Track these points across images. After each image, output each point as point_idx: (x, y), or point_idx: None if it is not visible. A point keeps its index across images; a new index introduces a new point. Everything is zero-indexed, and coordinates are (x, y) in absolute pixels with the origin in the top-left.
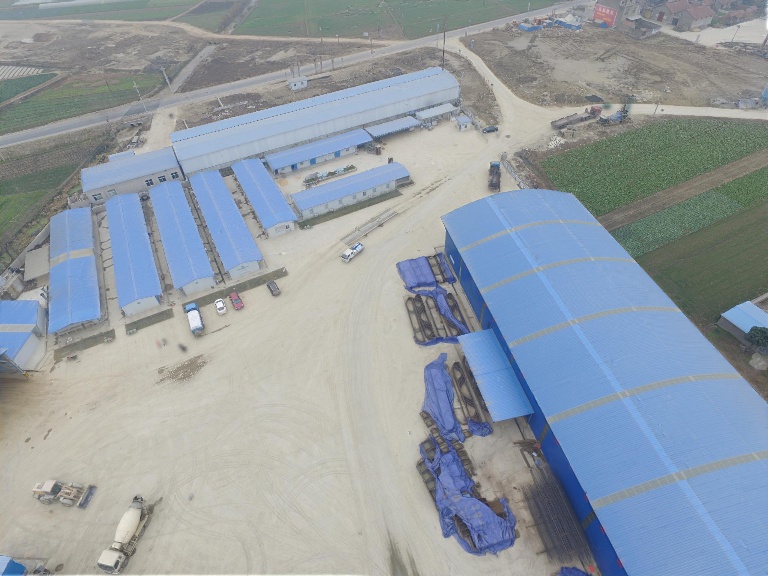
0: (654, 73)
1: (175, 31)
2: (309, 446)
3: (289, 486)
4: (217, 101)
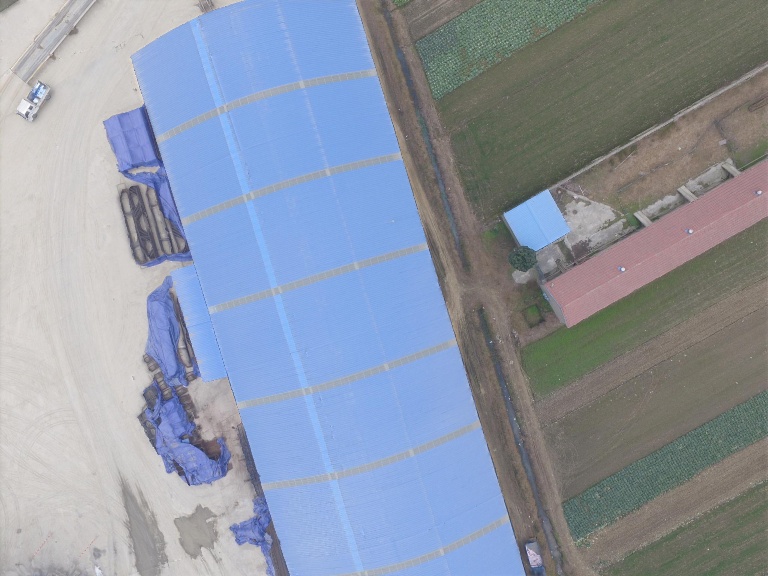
0: None
1: None
2: (33, 398)
3: (22, 438)
4: None
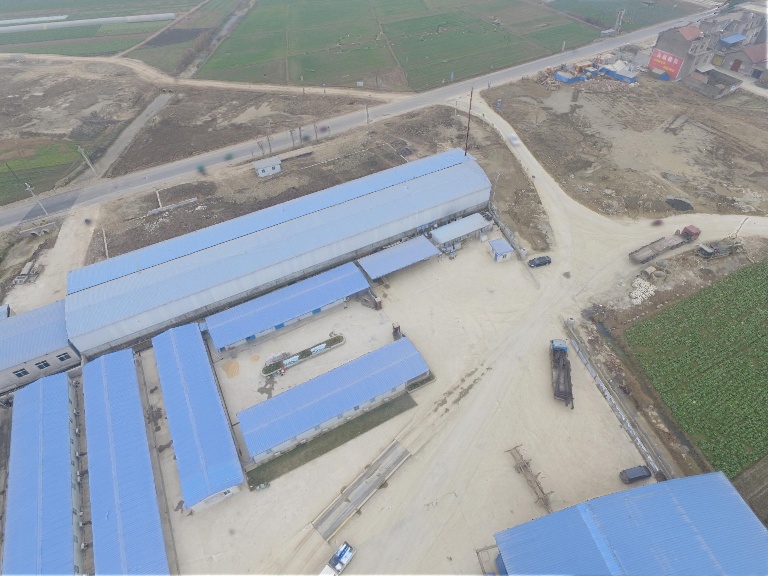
0: (750, 157)
1: (122, 73)
2: None
3: None
4: (156, 195)
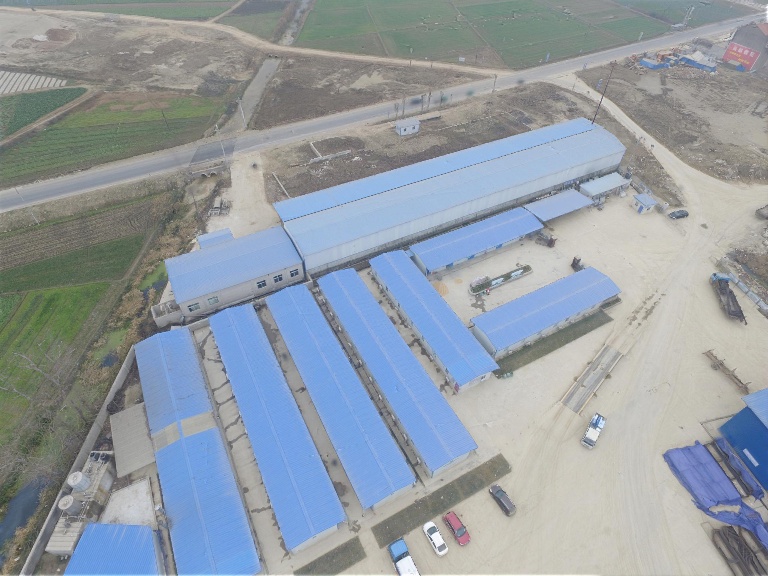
0: None
1: (223, 37)
2: None
3: None
4: (309, 146)
